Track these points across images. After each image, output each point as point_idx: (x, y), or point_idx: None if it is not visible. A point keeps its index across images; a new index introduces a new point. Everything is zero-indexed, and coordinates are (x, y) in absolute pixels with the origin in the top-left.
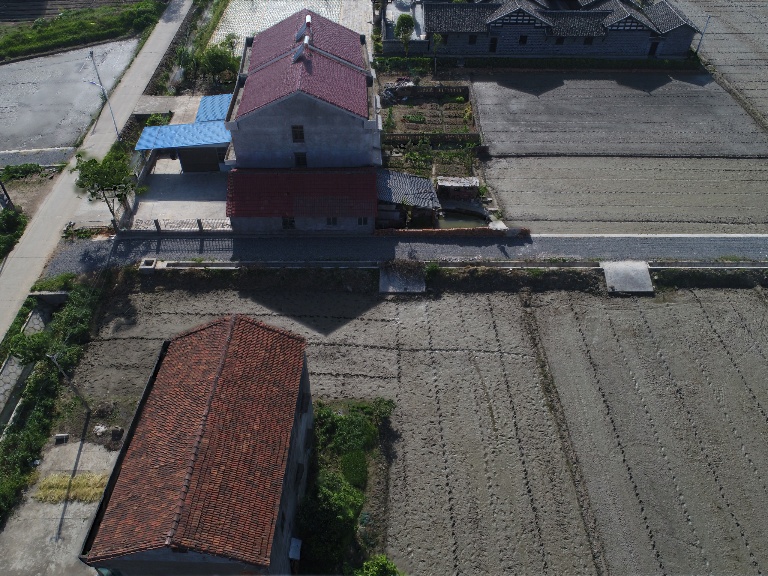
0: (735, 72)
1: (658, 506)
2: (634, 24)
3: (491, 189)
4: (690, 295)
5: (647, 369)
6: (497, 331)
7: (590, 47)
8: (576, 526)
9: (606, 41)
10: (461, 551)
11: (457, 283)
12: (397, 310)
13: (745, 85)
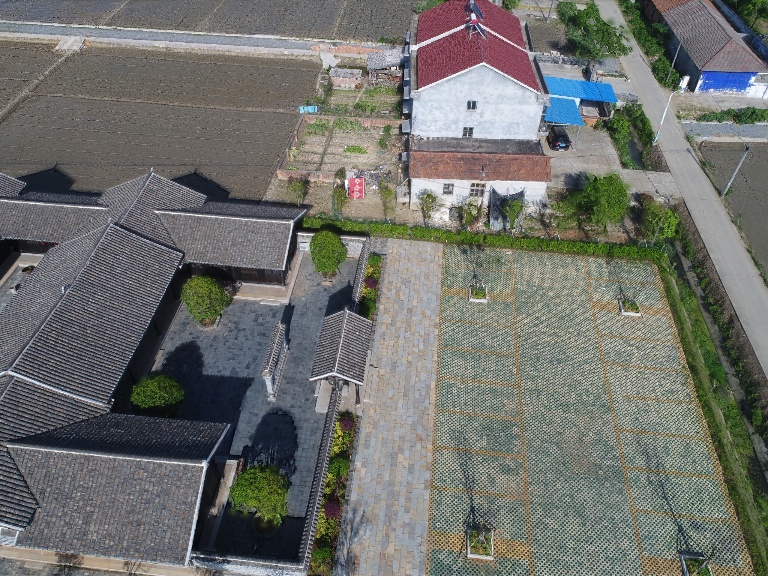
0: None
1: None
2: None
3: (317, 86)
4: None
5: None
6: None
7: None
8: None
9: None
10: None
11: None
12: None
13: None
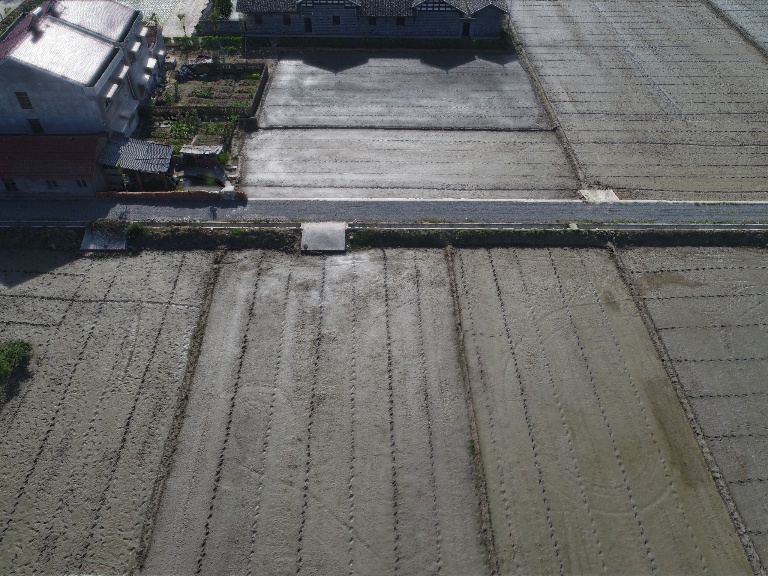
0: (541, 52)
1: (242, 438)
2: (442, 5)
3: (241, 158)
4: (380, 254)
5: (301, 319)
6: (176, 285)
7: (403, 27)
8: (155, 455)
9: (418, 21)
10: (34, 476)
11: (158, 242)
12: (90, 266)
13: (544, 64)
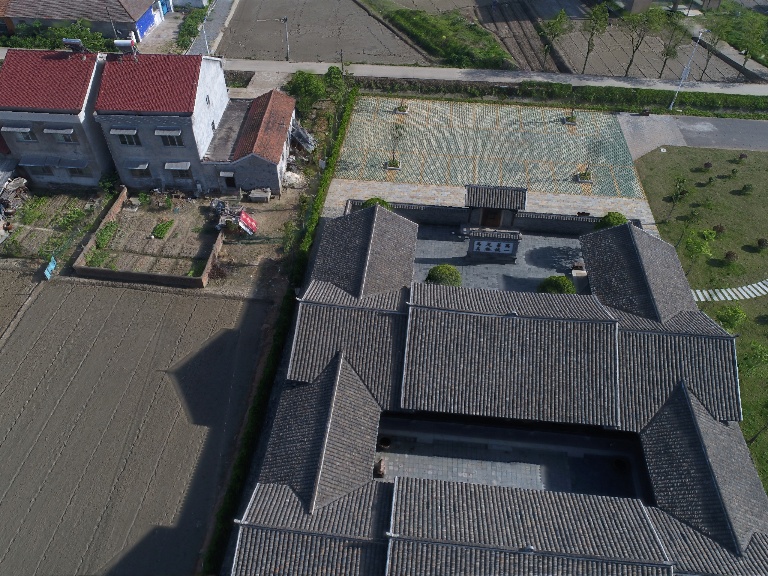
0: None
1: None
2: None
3: None
4: None
5: None
6: None
7: None
8: None
9: None
10: None
11: None
12: None
13: None
